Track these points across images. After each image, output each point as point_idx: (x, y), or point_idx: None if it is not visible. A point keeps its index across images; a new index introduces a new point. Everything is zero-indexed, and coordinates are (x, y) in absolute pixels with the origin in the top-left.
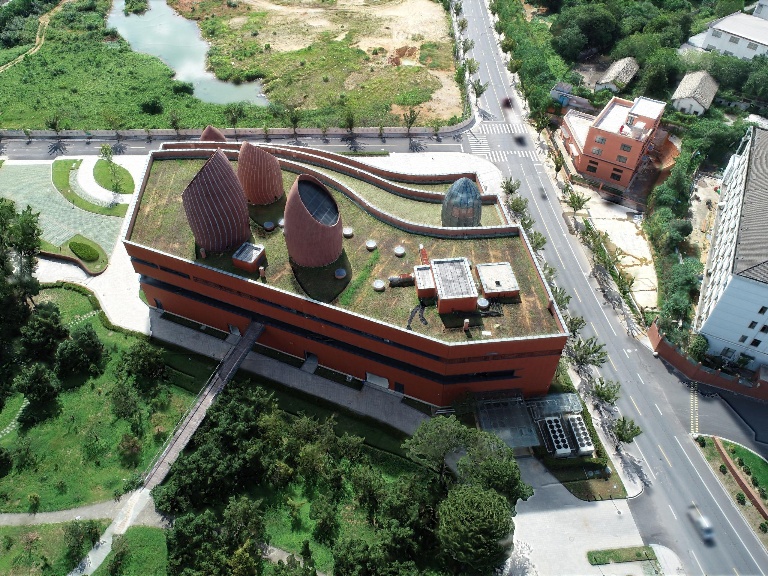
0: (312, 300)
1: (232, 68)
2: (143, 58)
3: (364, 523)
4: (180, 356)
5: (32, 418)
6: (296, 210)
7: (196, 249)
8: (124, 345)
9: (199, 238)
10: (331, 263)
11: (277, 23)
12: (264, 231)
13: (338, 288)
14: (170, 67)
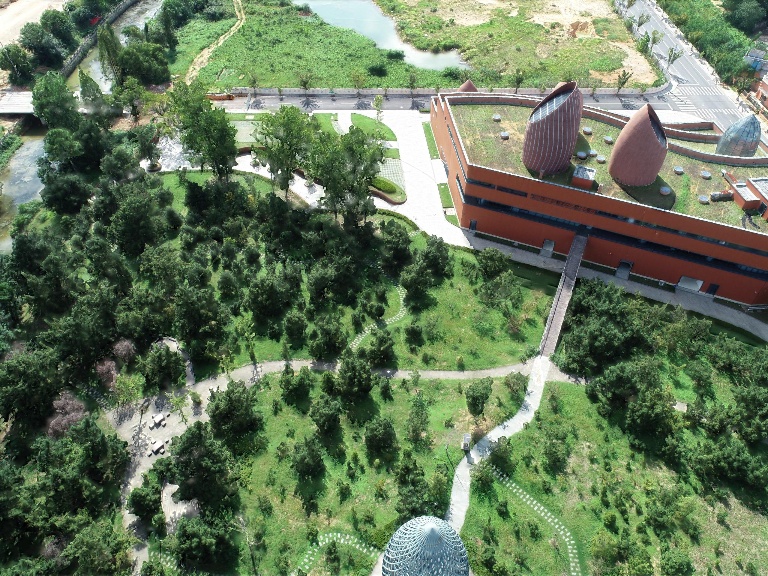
0: (658, 208)
1: (427, 39)
2: (343, 30)
3: (730, 385)
4: (509, 265)
5: (419, 305)
6: (644, 133)
7: (530, 172)
8: (457, 256)
9: (537, 162)
10: (652, 183)
11: (449, 1)
12: (579, 159)
13: (669, 202)
14: (368, 38)
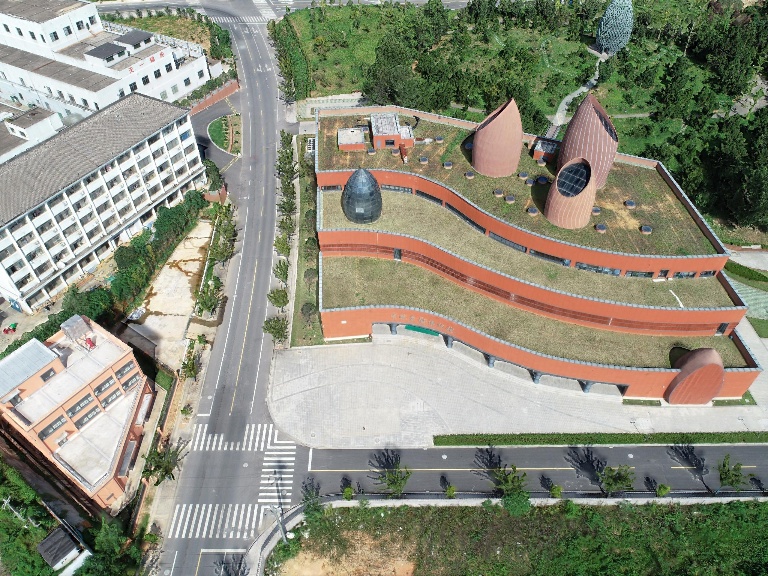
0: None
1: None
2: None
3: None
4: None
5: None
6: None
7: None
8: None
9: None
10: None
11: None
12: None
13: (469, 140)
14: None
